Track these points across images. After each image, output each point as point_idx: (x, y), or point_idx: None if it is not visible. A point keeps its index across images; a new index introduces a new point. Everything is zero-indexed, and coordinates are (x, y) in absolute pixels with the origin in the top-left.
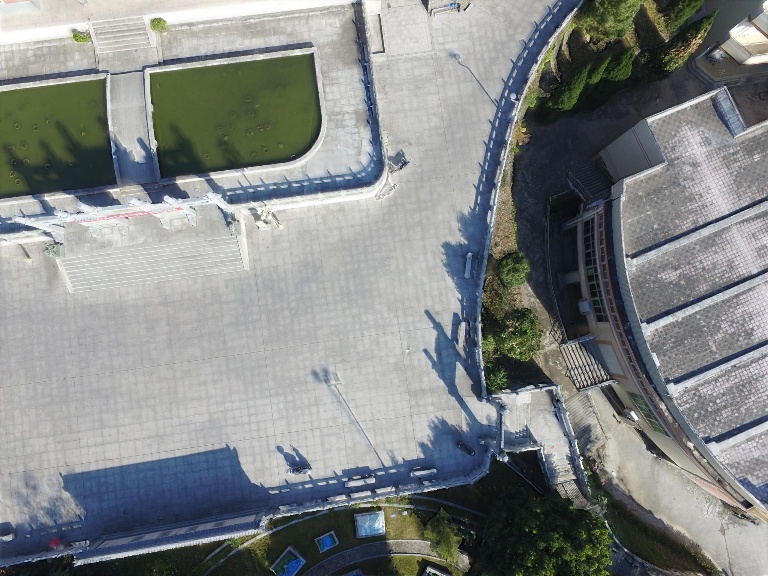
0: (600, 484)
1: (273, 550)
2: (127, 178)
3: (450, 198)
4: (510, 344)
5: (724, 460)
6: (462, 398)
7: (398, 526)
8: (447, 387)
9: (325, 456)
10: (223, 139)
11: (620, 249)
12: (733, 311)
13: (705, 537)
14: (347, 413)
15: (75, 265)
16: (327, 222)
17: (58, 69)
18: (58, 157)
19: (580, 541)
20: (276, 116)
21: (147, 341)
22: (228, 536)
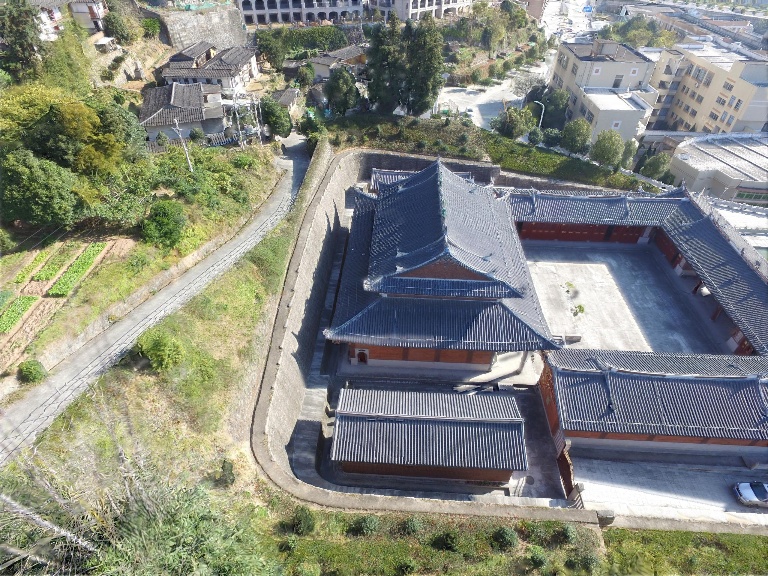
0: None
1: None
2: None
3: None
4: None
5: None
6: None
7: None
8: None
9: None
10: None
11: (766, 184)
12: None
13: None
14: None
15: None
16: None
17: None
18: None
19: None
20: None
21: None
22: None
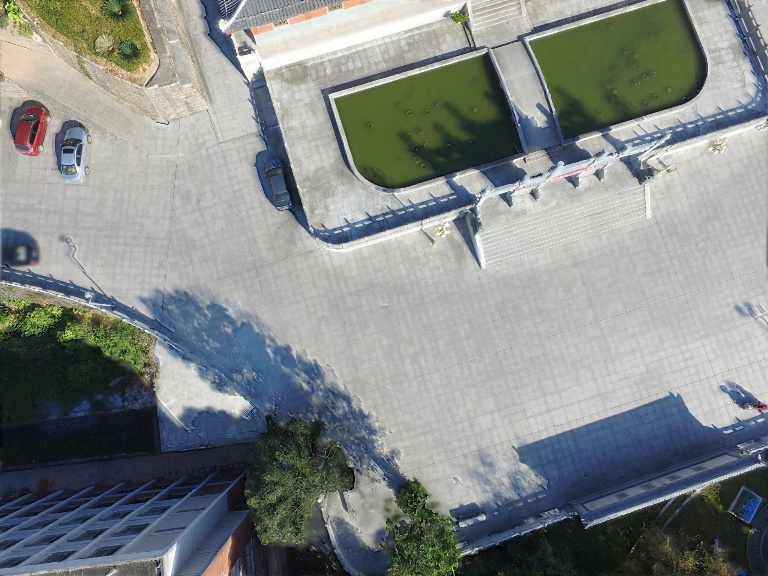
0: None
1: (725, 492)
2: (532, 145)
3: None
4: None
5: None
6: None
7: None
8: None
9: None
10: (612, 93)
11: None
12: None
13: None
14: None
15: (491, 239)
16: (714, 160)
17: (433, 53)
18: (456, 136)
19: None
20: (656, 63)
21: (567, 303)
22: (729, 475)
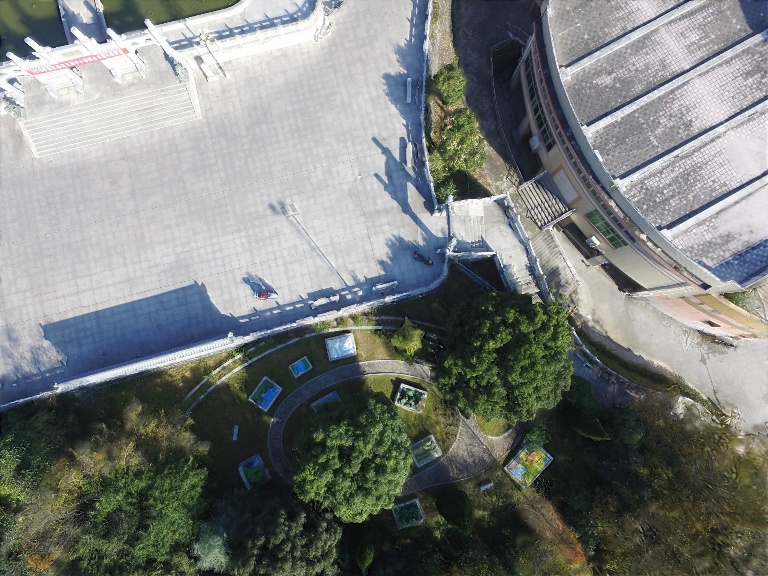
0: (576, 326)
1: (250, 382)
2: None
3: (386, 33)
4: (452, 145)
5: (677, 246)
6: (416, 215)
7: (369, 348)
8: (401, 206)
9: (290, 282)
10: None
11: (552, 57)
12: (670, 106)
13: (687, 368)
14: (307, 240)
15: (37, 127)
16: (271, 67)
17: None
18: (13, 29)
19: (535, 311)
20: None
21: (111, 194)
22: (199, 350)
